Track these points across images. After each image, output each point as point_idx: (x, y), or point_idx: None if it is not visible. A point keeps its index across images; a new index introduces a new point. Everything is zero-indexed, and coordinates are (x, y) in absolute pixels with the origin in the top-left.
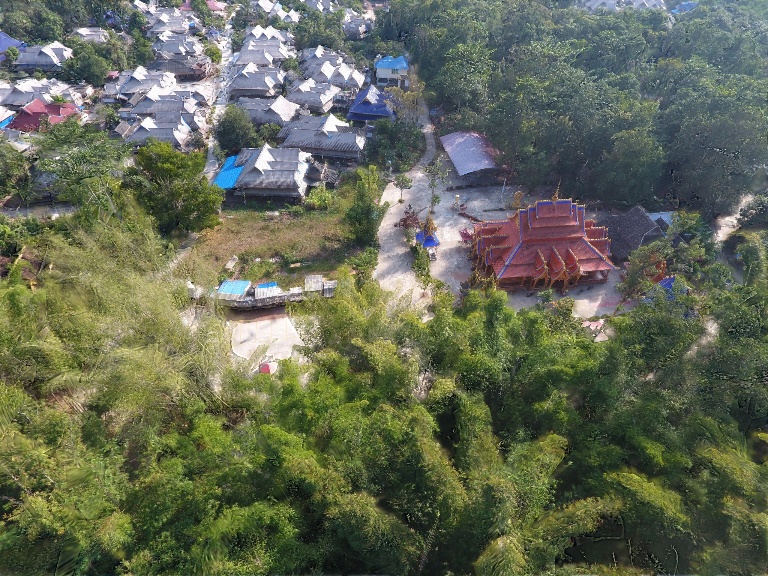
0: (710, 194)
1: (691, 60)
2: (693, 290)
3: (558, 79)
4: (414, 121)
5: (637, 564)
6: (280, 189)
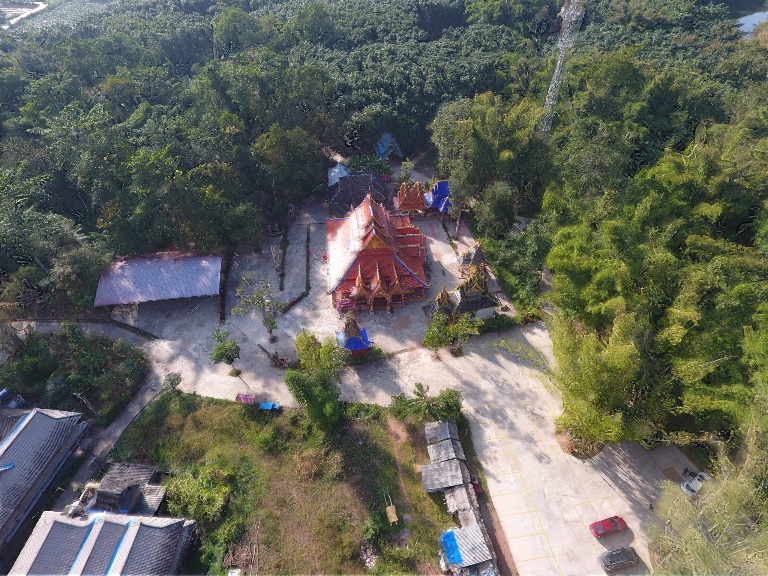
0: (340, 138)
1: (118, 73)
2: (423, 188)
3: (122, 145)
4: (11, 333)
5: (726, 238)
6: (168, 567)
